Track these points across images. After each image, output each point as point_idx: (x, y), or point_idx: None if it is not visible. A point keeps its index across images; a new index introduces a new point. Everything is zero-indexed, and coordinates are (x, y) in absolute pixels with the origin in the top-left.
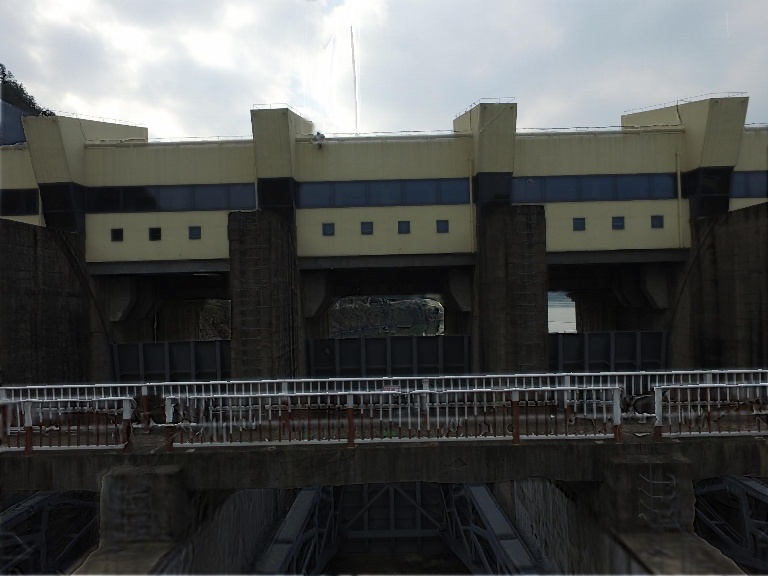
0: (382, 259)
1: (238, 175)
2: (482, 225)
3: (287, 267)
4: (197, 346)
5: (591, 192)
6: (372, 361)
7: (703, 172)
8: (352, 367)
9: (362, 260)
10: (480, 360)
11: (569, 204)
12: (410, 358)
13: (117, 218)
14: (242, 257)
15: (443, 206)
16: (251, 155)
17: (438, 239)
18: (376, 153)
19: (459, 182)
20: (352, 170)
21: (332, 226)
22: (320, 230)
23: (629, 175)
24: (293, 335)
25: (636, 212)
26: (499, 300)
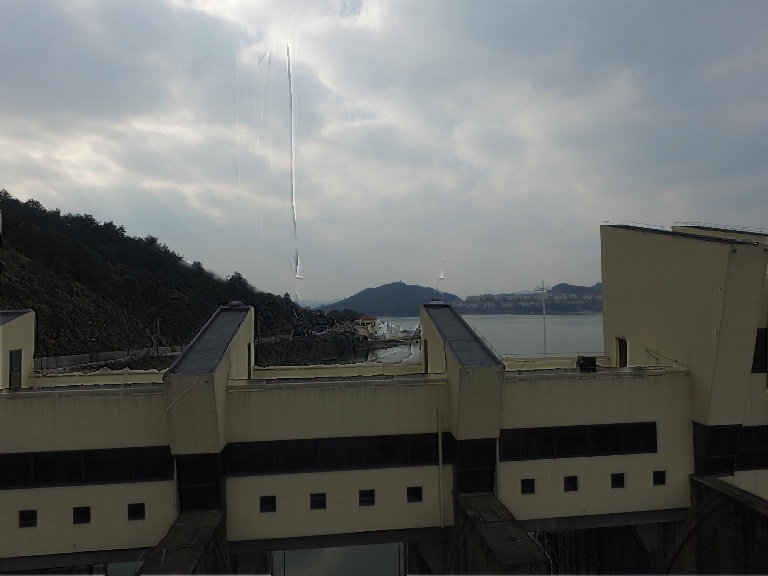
0: (51, 558)
1: None
2: None
3: None
4: None
5: (336, 456)
6: None
7: (460, 445)
8: None
9: (22, 560)
10: None
11: (306, 476)
12: None
13: None
14: None
15: (138, 484)
16: None
17: (130, 529)
18: (45, 415)
19: (162, 450)
20: (9, 439)
21: None
22: None
23: (381, 437)
24: None
25: (389, 483)
26: None
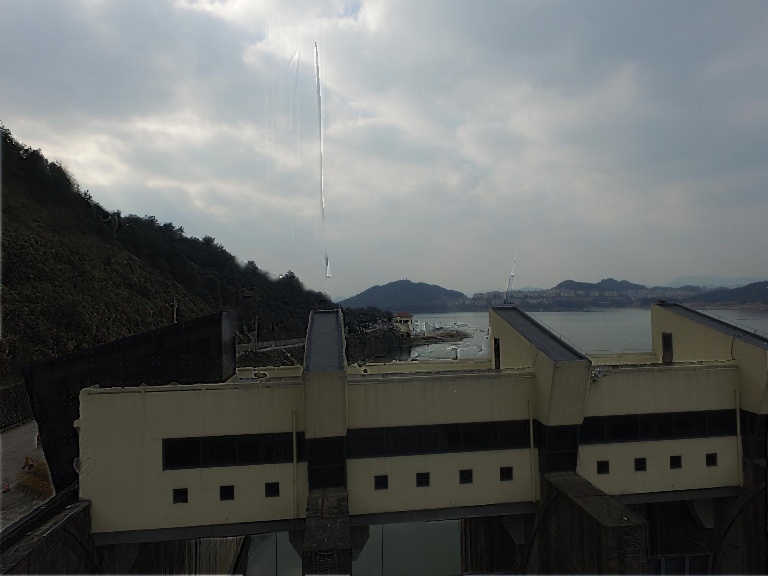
0: (653, 495)
1: (510, 411)
2: None
3: None
4: None
5: None
6: None
7: None
8: None
9: (633, 497)
10: None
11: None
12: None
13: (380, 463)
14: None
15: (711, 439)
16: (523, 389)
17: (707, 473)
18: (648, 385)
19: (725, 413)
20: (624, 403)
21: (606, 463)
22: (595, 469)
23: None
24: None
25: None
26: None
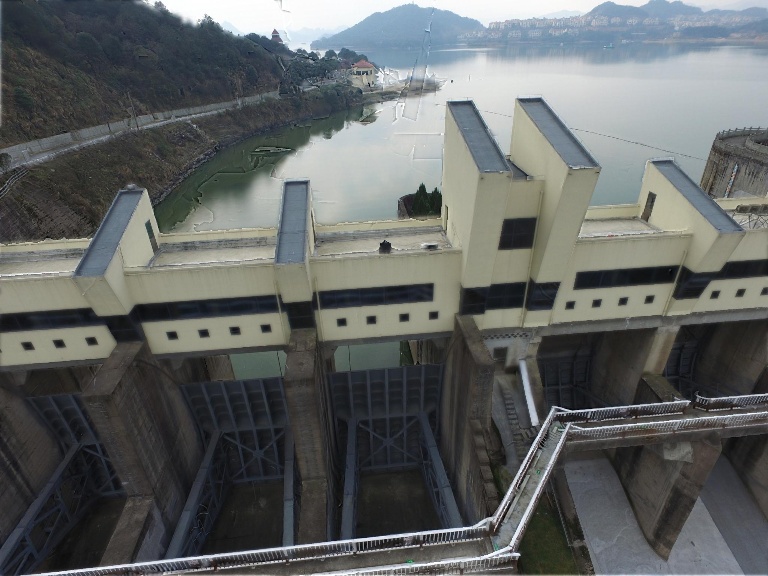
0: (52, 363)
1: None
2: None
3: None
4: None
5: (211, 309)
6: None
7: (287, 305)
8: (73, 407)
9: (35, 365)
10: None
11: (192, 321)
12: None
13: None
14: None
15: (87, 328)
16: None
17: (91, 350)
18: (10, 293)
19: None
20: None
21: None
22: None
23: (238, 298)
24: None
25: (248, 323)
26: None
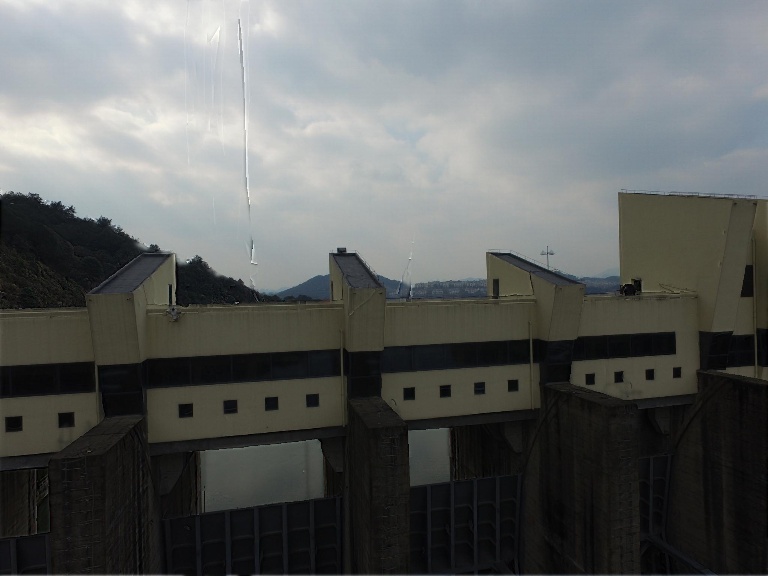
0: (247, 438)
1: (73, 353)
2: (351, 410)
3: (131, 480)
4: (20, 543)
5: (456, 358)
6: (238, 531)
7: (550, 345)
8: (216, 540)
9: (225, 440)
10: (350, 536)
11: (436, 372)
12: (280, 525)
13: None
14: (67, 512)
15: (313, 379)
16: None
17: (308, 414)
18: (241, 325)
19: (330, 353)
20: (214, 344)
21: (190, 406)
22: (176, 412)
23: (489, 343)
24: (140, 546)
25: (495, 377)
26: (365, 513)
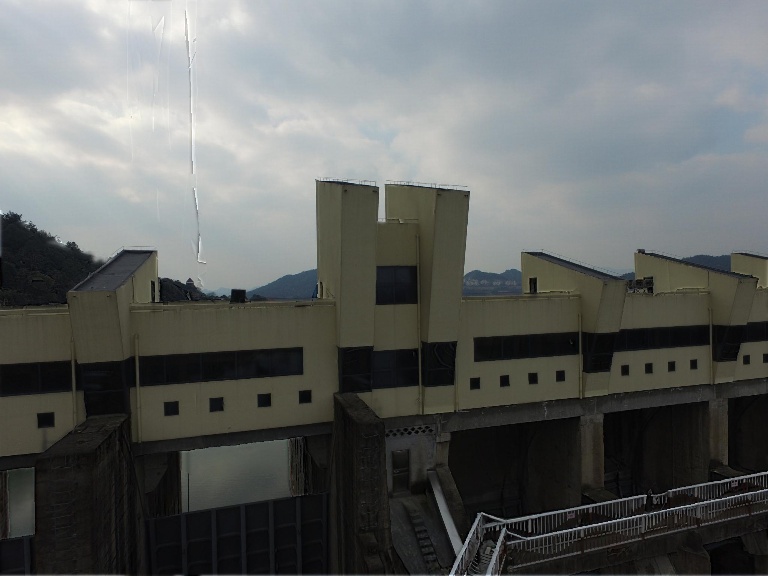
0: None
1: None
2: None
3: None
4: None
5: None
6: None
7: (83, 369)
8: None
9: None
10: None
11: None
12: None
13: None
14: None
15: None
16: None
17: None
18: None
19: None
20: None
21: None
22: None
23: (7, 366)
24: None
25: (16, 410)
26: None
